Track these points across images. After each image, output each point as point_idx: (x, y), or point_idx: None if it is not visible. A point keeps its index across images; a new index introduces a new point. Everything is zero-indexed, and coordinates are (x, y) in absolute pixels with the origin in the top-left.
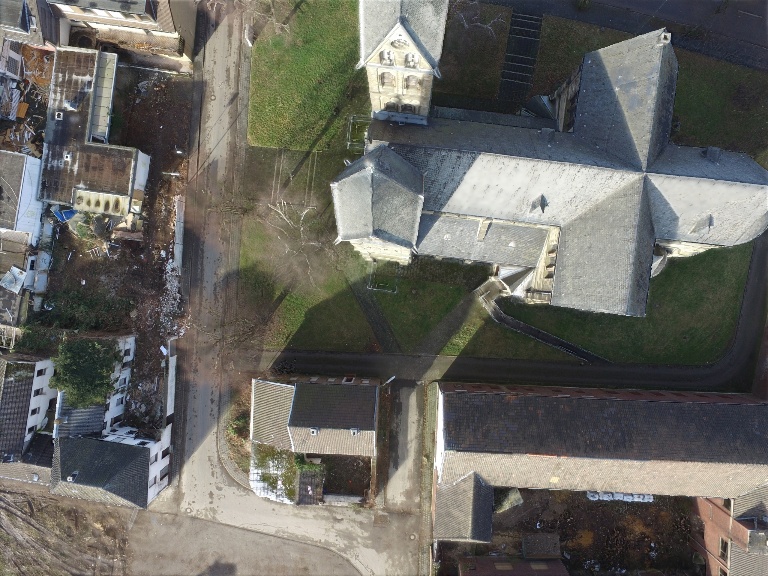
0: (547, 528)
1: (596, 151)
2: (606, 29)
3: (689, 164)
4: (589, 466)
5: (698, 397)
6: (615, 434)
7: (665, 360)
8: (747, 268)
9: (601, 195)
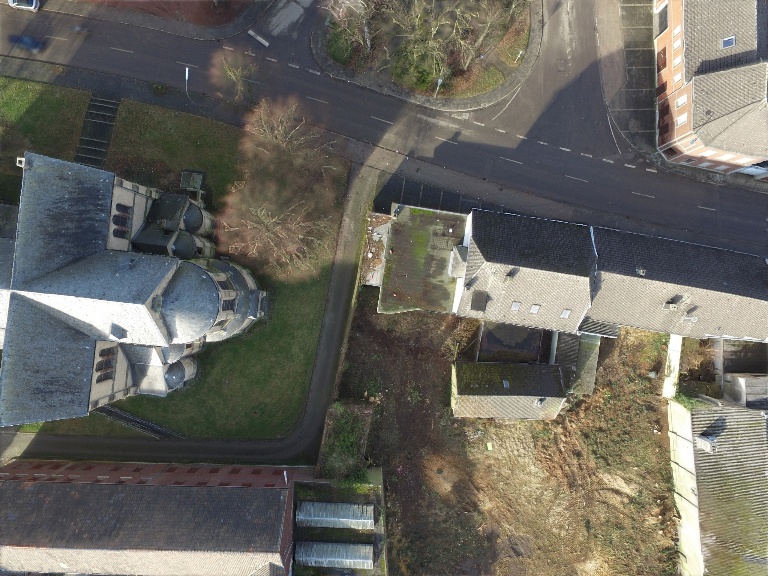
0: None
1: (3, 262)
2: (181, 113)
3: (82, 276)
4: (78, 555)
5: (245, 474)
6: (109, 522)
7: (237, 434)
8: (315, 344)
9: (3, 306)
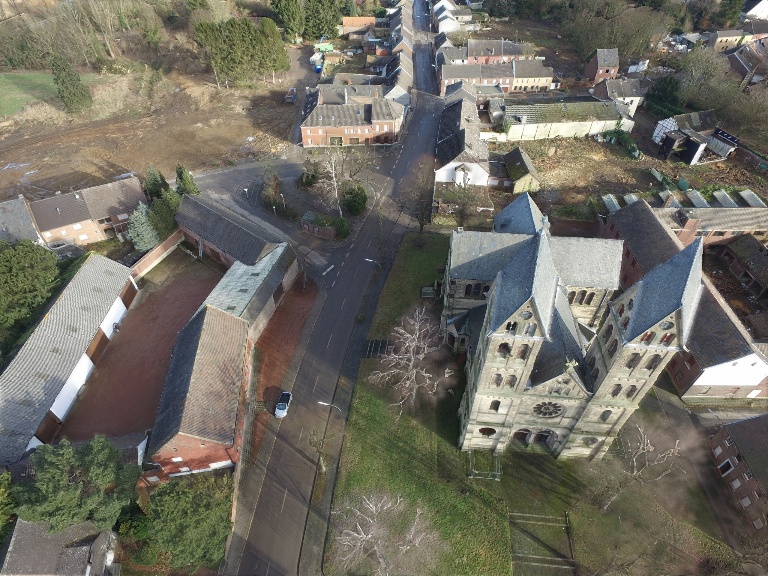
0: (746, 324)
1: None
2: None
3: (518, 227)
4: (703, 279)
5: None
6: None
7: None
8: None
9: None
